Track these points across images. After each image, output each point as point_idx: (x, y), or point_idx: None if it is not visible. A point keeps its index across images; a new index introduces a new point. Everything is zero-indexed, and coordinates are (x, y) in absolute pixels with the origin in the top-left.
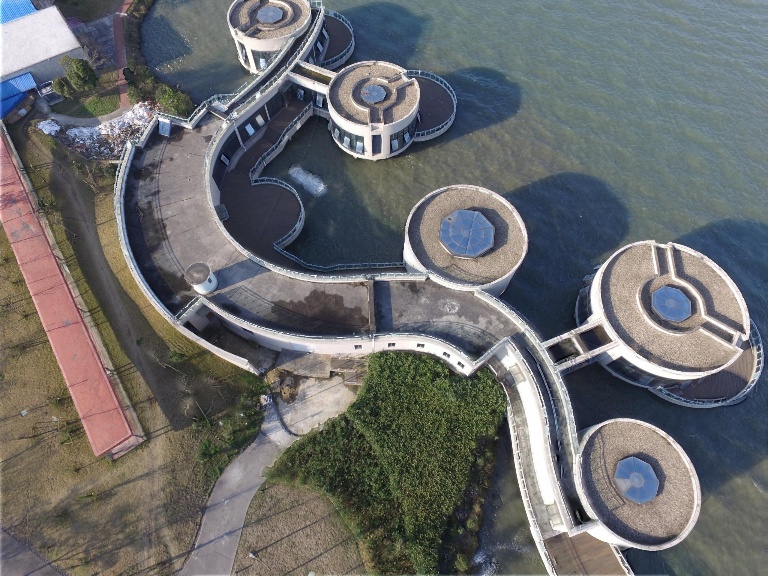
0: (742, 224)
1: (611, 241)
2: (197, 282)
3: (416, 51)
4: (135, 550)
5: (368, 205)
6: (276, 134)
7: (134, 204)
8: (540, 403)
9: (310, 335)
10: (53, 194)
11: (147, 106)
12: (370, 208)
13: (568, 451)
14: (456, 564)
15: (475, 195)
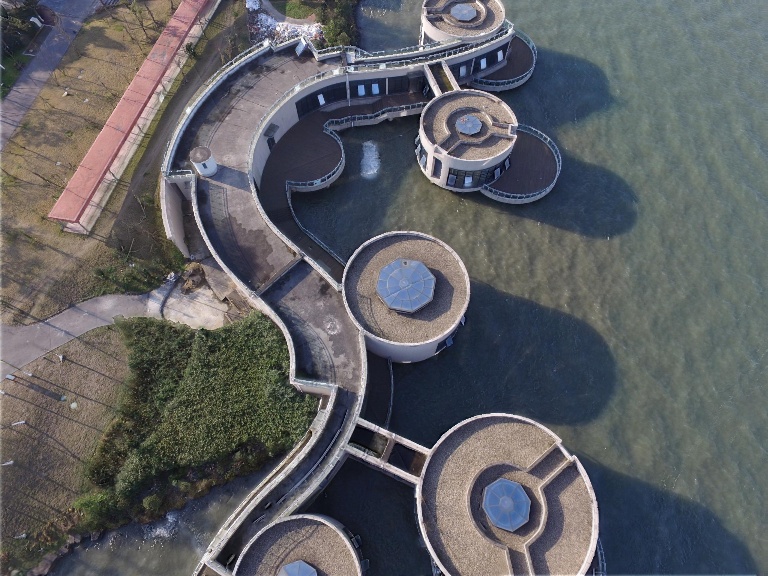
0: (725, 533)
1: (557, 415)
2: (194, 159)
3: (574, 122)
4: (19, 290)
5: (390, 211)
6: (381, 108)
7: (230, 85)
8: (302, 455)
9: (226, 257)
10: (206, 47)
11: (321, 29)
12: (389, 215)
13: (282, 511)
14: (145, 498)
15: (453, 264)
